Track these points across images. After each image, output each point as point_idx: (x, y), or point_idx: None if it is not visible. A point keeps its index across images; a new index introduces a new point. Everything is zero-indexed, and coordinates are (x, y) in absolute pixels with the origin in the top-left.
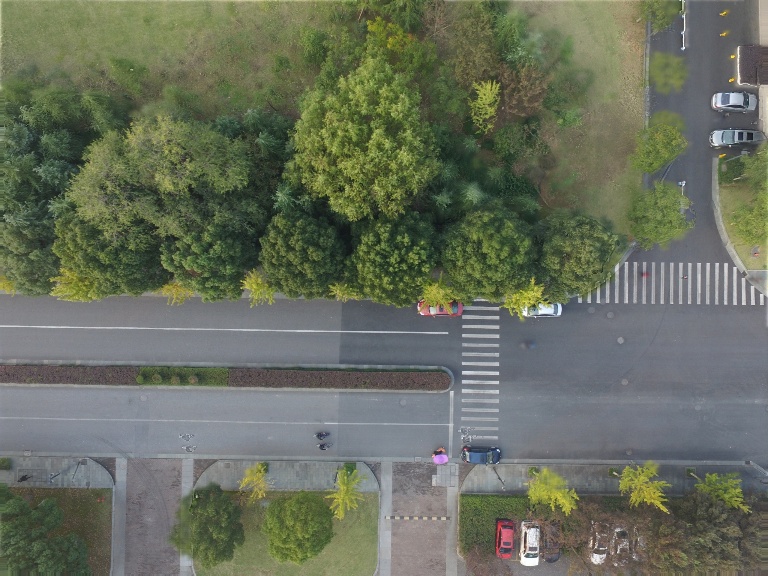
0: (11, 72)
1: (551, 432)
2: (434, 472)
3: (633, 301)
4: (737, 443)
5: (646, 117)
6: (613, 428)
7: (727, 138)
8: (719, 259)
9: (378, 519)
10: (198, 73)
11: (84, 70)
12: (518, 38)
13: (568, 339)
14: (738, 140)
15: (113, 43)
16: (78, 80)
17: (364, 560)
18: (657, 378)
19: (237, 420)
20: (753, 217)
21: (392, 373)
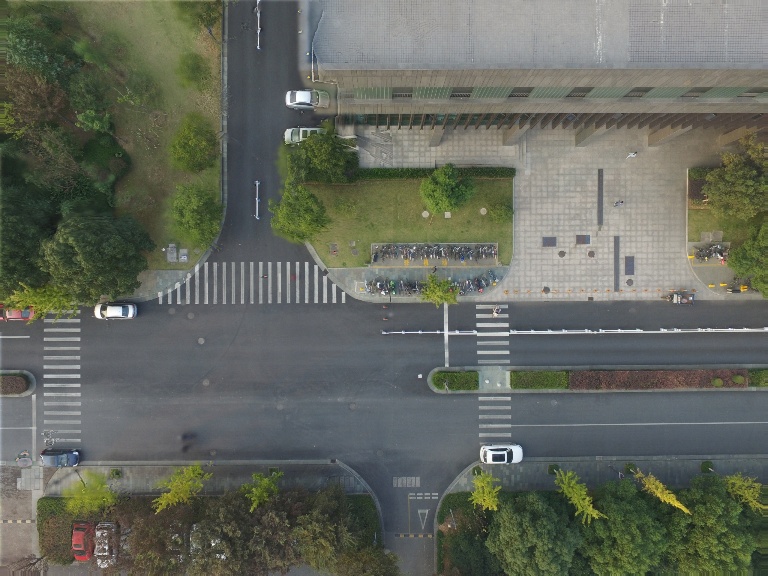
0: None
1: (134, 434)
2: (19, 475)
3: (213, 301)
4: (321, 442)
5: (225, 117)
6: (196, 429)
7: (295, 136)
8: (299, 258)
9: None
10: None
11: None
12: (74, 41)
13: (146, 341)
14: (302, 138)
15: None
16: None
17: None
18: (238, 378)
19: None
20: (282, 215)
21: None
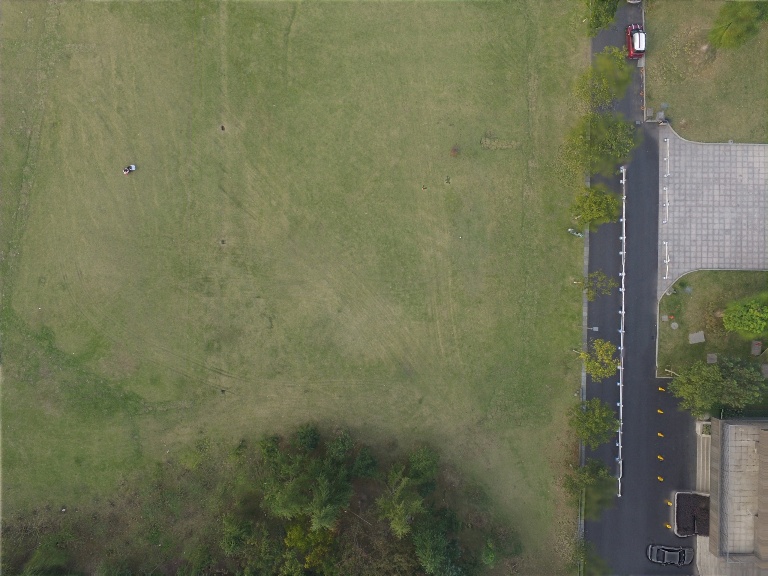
0: None
1: None
2: None
3: None
4: None
5: (581, 561)
6: None
7: None
8: None
9: None
10: (129, 517)
11: (17, 509)
12: (447, 505)
13: None
14: None
15: (45, 483)
16: (11, 520)
17: None
18: None
19: None
20: None
21: None
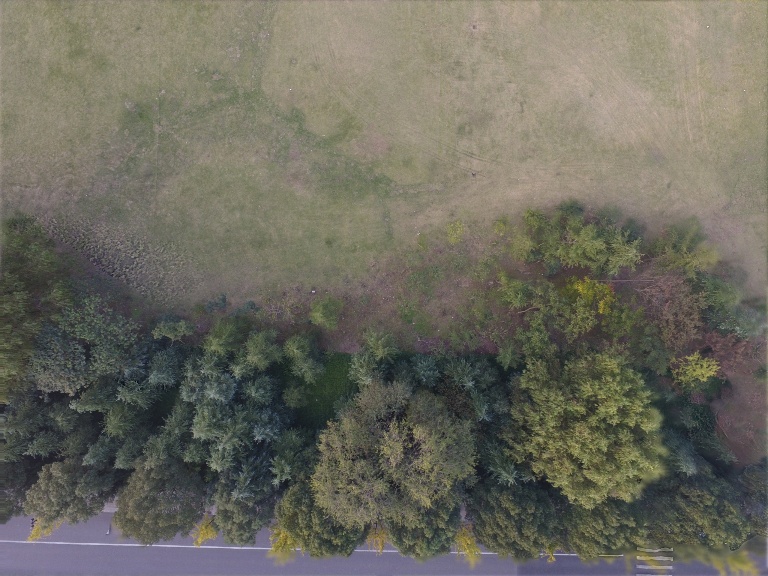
0: (191, 292)
1: None
2: None
3: None
4: None
5: None
6: None
7: None
8: None
9: None
10: (381, 297)
11: (265, 291)
12: (707, 277)
13: (740, 562)
14: None
15: (295, 264)
16: (259, 301)
17: None
18: None
19: None
20: None
21: None
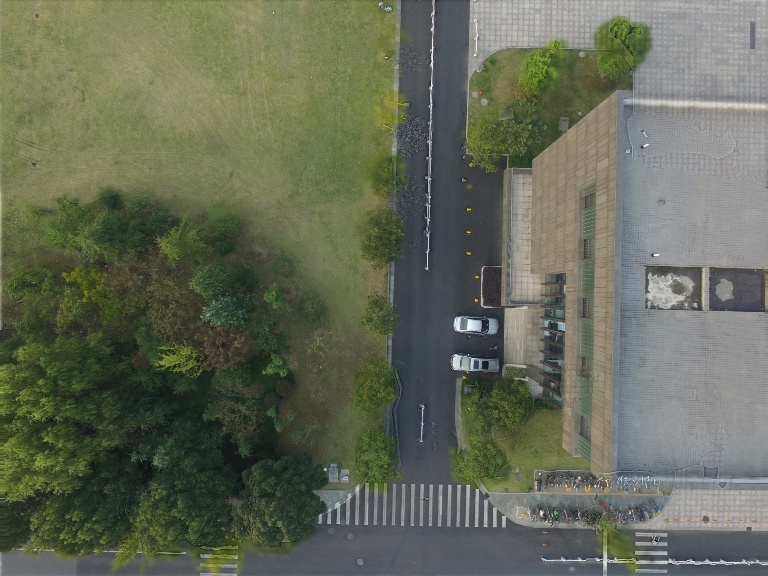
0: None
1: None
2: None
3: (373, 522)
4: None
5: (390, 336)
6: None
7: (465, 364)
8: (461, 481)
9: None
10: None
11: None
12: (247, 266)
13: (305, 561)
14: (473, 368)
15: None
16: None
17: None
18: None
19: None
20: (465, 466)
21: None
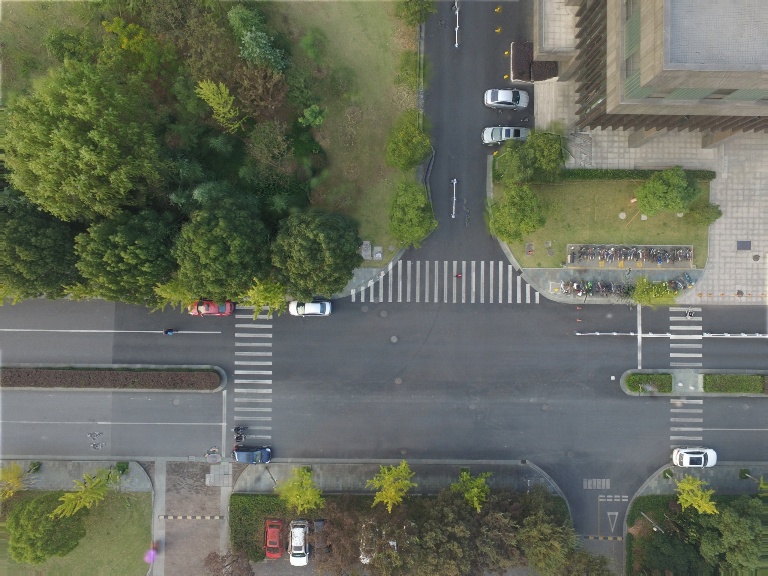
0: None
1: (324, 431)
2: (208, 471)
3: (406, 300)
4: (512, 442)
5: (421, 114)
6: (387, 427)
7: (496, 135)
8: (494, 257)
9: (152, 518)
10: None
11: None
12: None
13: (340, 338)
14: (505, 137)
15: None
16: None
17: (137, 559)
18: (431, 377)
19: (11, 420)
20: (500, 215)
21: (161, 373)
